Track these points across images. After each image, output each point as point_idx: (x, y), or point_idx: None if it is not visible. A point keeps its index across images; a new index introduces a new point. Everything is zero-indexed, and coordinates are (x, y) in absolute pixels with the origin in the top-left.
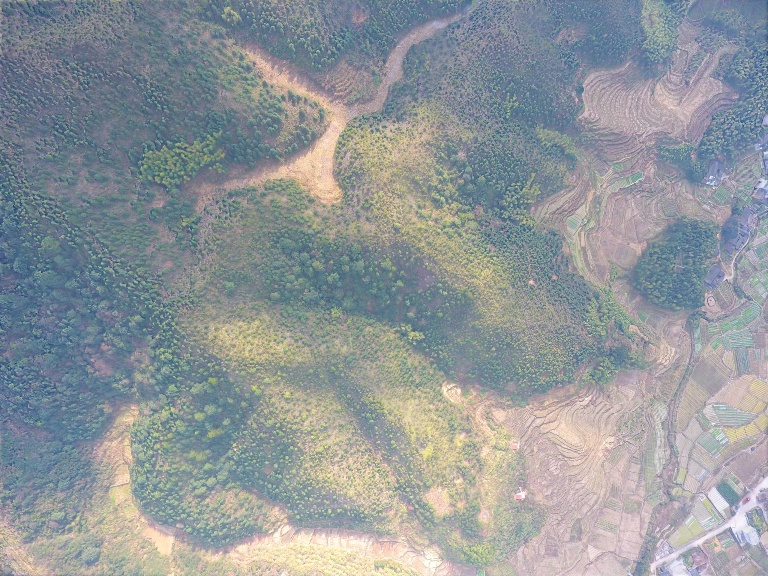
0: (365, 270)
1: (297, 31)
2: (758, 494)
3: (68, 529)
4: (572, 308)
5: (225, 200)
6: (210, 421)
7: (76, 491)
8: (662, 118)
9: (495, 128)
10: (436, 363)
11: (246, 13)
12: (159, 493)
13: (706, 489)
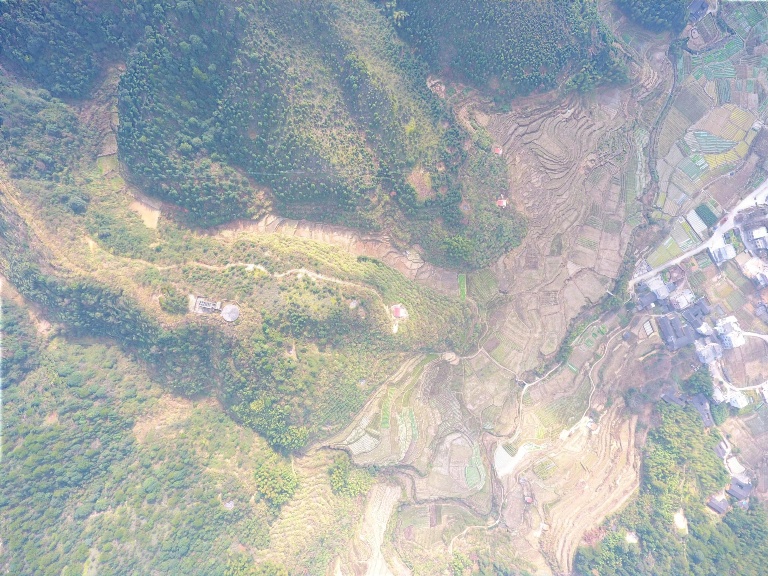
0: None
1: None
2: (736, 215)
3: (55, 178)
4: (555, 0)
5: None
6: (195, 60)
7: (64, 144)
8: None
9: None
10: (420, 54)
11: None
12: (145, 137)
13: (685, 212)
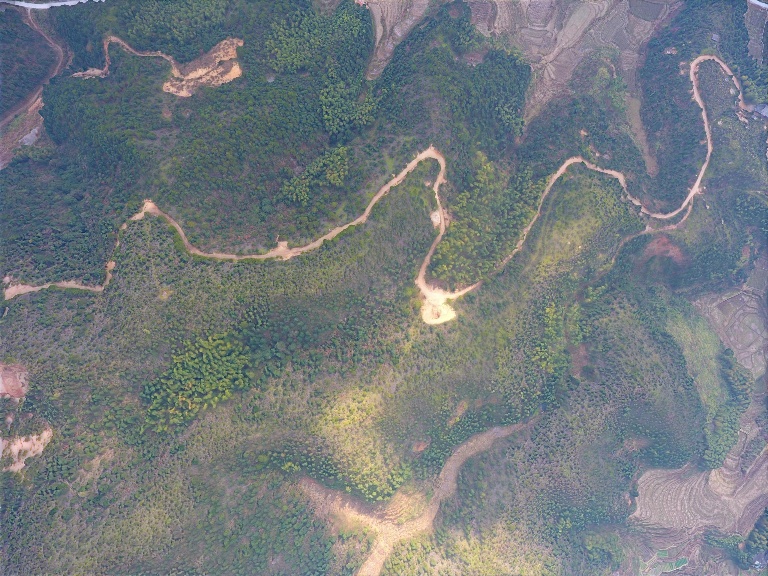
0: None
1: (356, 479)
2: None
3: None
4: None
5: None
6: None
7: None
8: (714, 510)
9: (545, 560)
10: None
11: (306, 465)
12: None
13: None
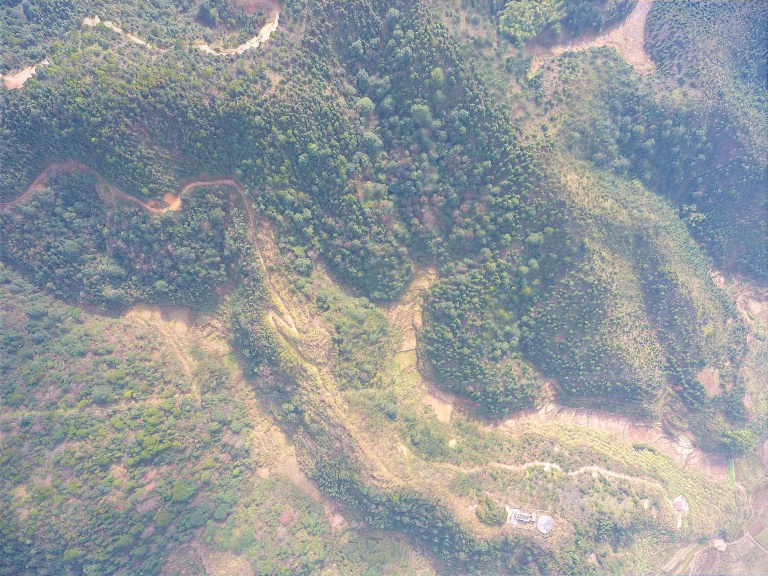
0: (678, 139)
1: None
2: None
3: (371, 384)
4: None
5: (563, 59)
6: None
7: (377, 348)
8: None
9: None
10: (706, 248)
11: None
12: (467, 349)
13: None
